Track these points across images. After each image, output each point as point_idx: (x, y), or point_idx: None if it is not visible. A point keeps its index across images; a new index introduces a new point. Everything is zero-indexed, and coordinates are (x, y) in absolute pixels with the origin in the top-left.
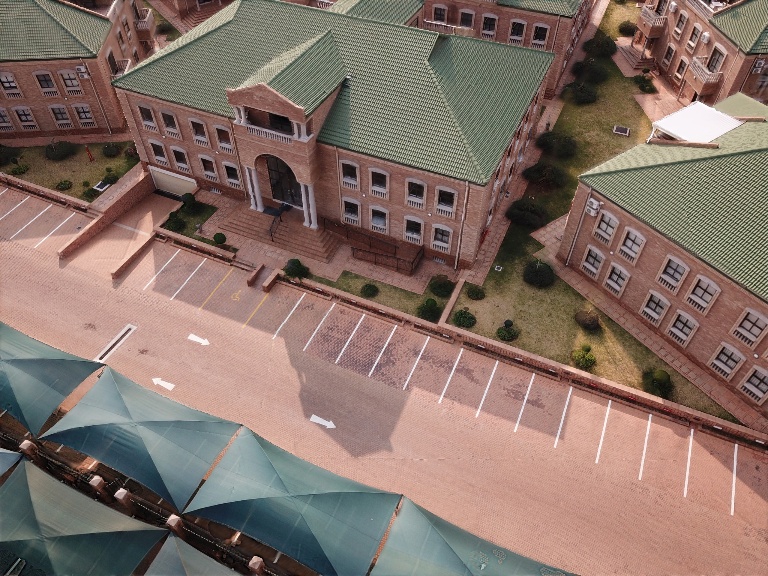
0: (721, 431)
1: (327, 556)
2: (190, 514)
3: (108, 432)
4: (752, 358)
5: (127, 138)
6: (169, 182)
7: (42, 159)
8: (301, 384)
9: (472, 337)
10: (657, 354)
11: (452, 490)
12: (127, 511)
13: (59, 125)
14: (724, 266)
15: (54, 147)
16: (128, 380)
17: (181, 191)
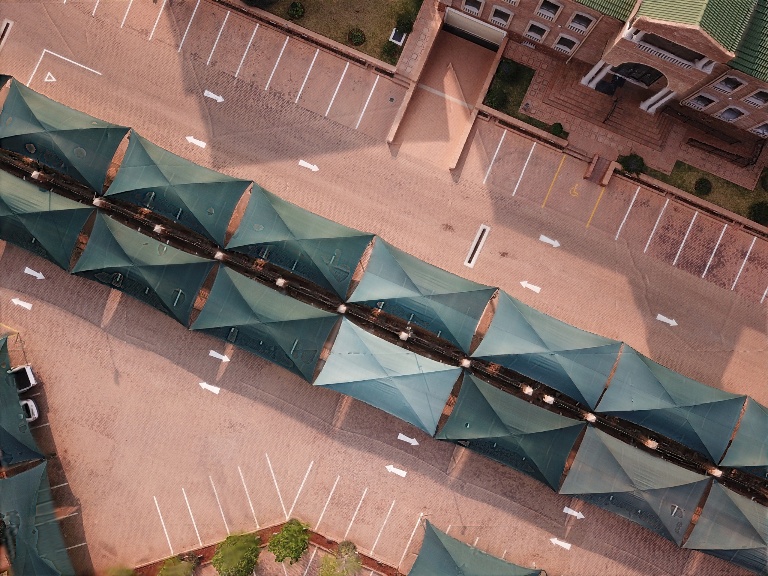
0: None
1: (704, 444)
2: (601, 413)
3: (532, 359)
4: None
5: None
6: (466, 22)
7: None
8: (646, 286)
9: None
10: None
11: (767, 375)
12: (553, 408)
13: None
14: None
15: None
16: (525, 306)
17: (478, 32)
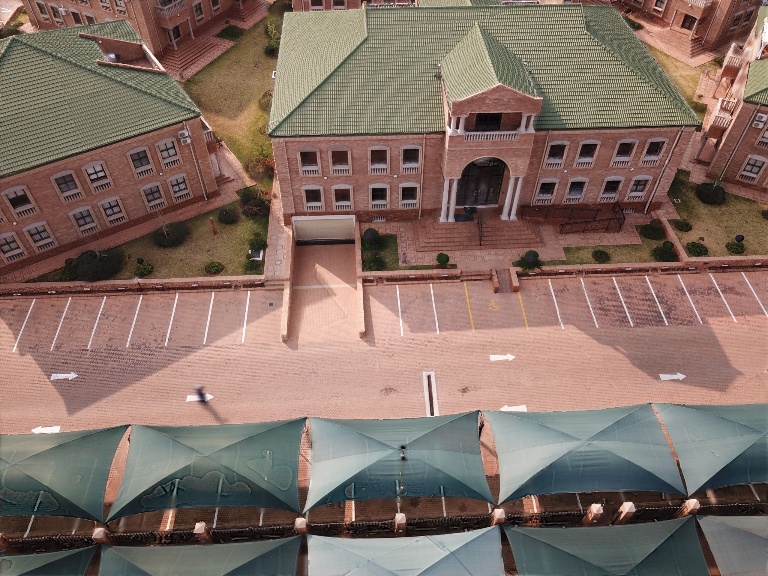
0: None
1: None
2: (698, 492)
3: (571, 461)
4: None
5: (229, 199)
6: (315, 228)
7: (156, 250)
8: (625, 355)
9: (718, 260)
10: None
11: None
12: (642, 520)
13: (150, 208)
14: None
15: (166, 232)
16: (521, 412)
17: (329, 233)
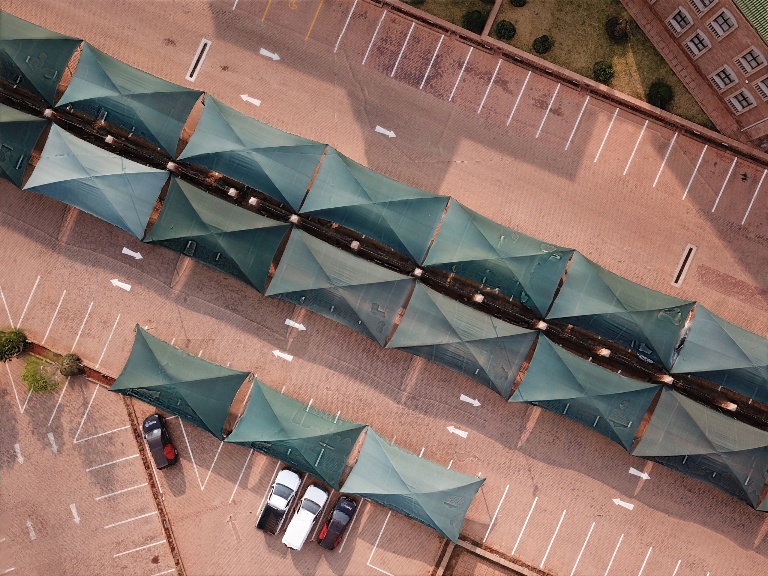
0: (699, 135)
1: (402, 241)
2: (304, 214)
3: (231, 157)
4: (743, 82)
5: None
6: None
7: None
8: (364, 98)
9: (511, 51)
10: (669, 64)
11: (485, 185)
12: (260, 211)
13: None
14: (747, 8)
15: None
16: (229, 108)
17: None
